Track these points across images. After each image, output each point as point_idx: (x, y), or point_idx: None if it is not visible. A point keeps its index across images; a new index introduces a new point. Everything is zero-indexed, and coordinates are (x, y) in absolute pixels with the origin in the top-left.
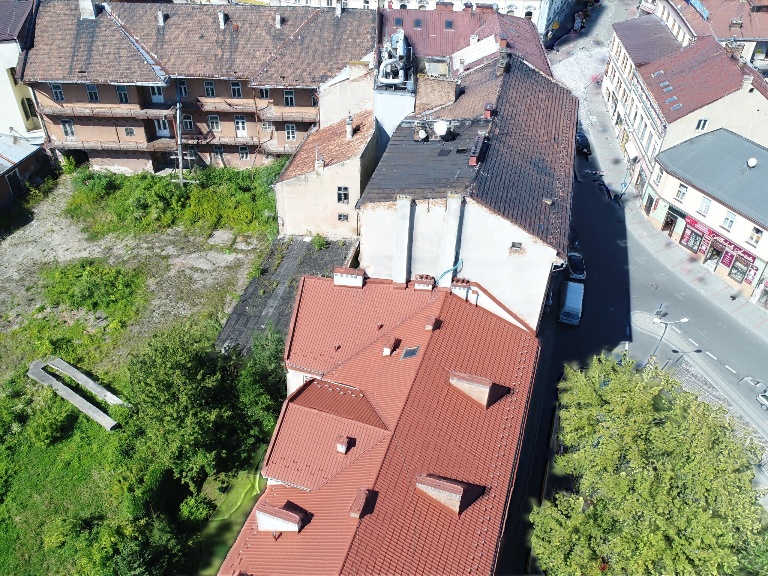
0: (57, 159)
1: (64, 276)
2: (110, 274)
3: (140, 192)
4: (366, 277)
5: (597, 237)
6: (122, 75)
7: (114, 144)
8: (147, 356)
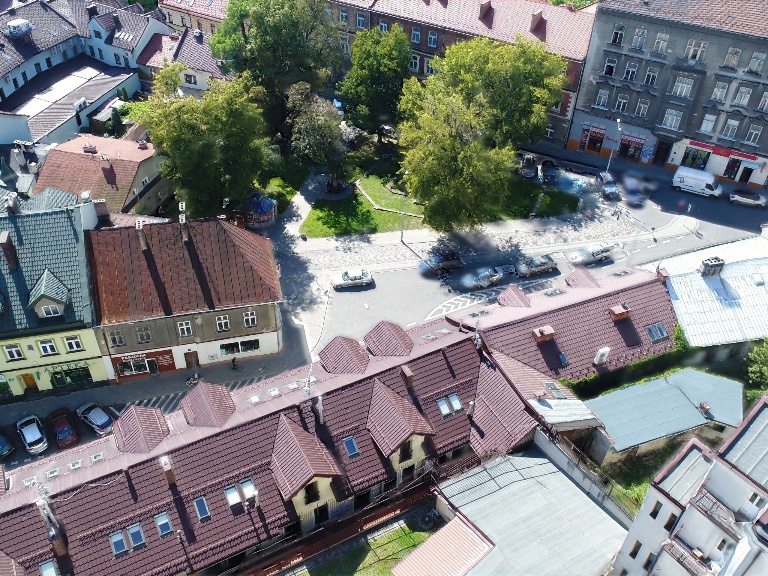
0: None
1: None
2: None
3: None
4: None
5: None
6: None
7: None
8: None
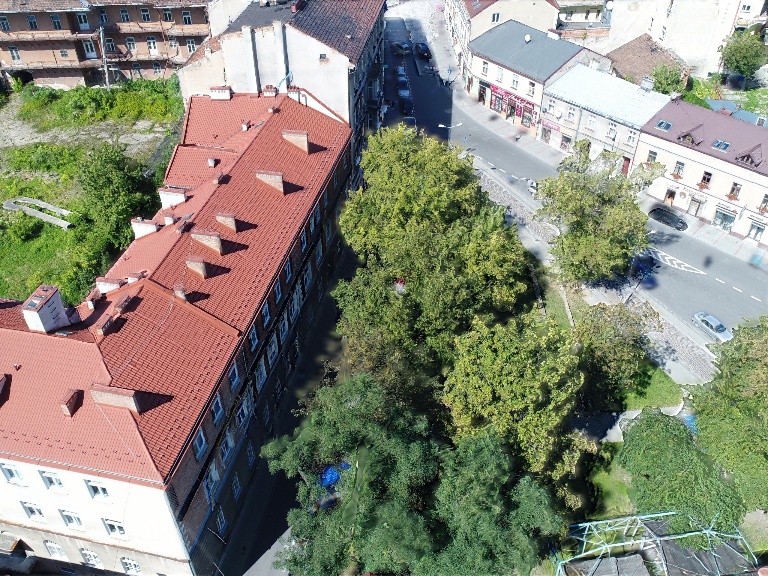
0: (7, 81)
1: (22, 153)
2: (58, 148)
3: (76, 98)
4: (232, 93)
5: (430, 108)
6: (55, 5)
7: (53, 65)
8: (89, 162)
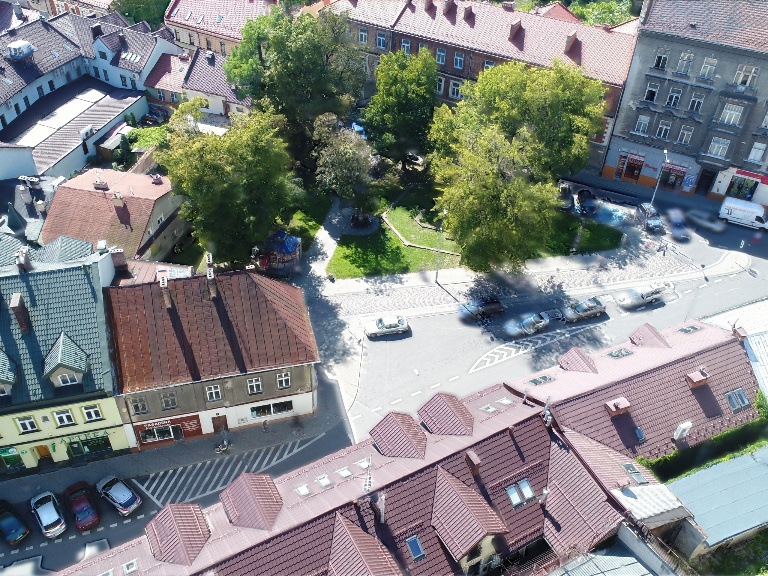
0: None
1: None
2: None
3: None
4: None
5: None
6: None
7: None
8: None
